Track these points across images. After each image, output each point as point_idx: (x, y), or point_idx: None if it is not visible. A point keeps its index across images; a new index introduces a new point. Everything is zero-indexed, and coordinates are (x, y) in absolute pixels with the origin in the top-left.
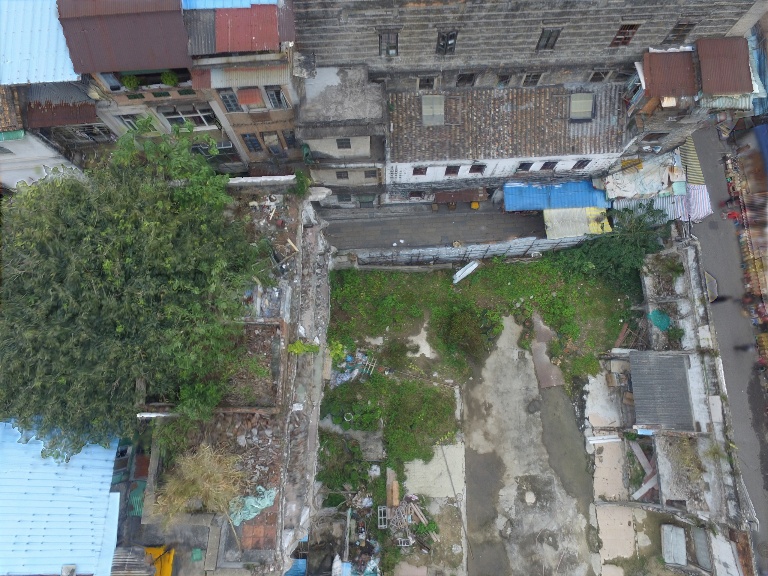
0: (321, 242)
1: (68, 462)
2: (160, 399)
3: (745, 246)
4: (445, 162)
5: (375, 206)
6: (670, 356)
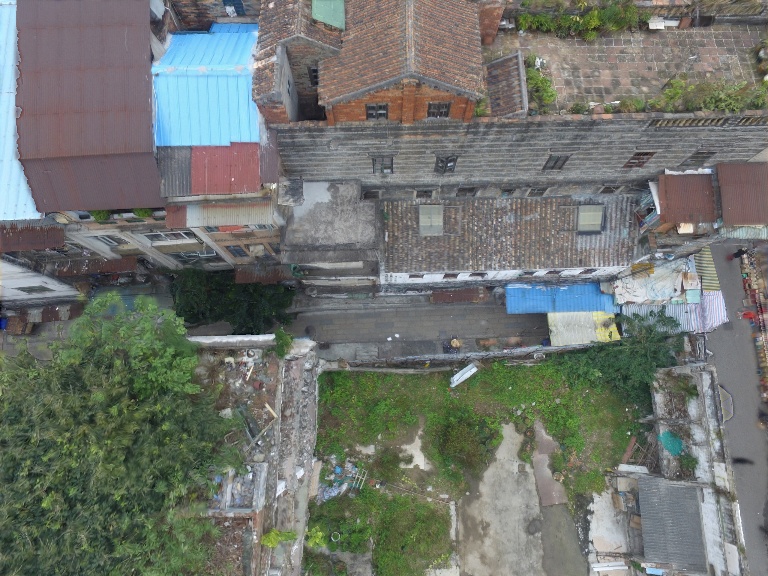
0: (308, 364)
1: None
2: None
3: (762, 351)
4: (443, 271)
5: (370, 297)
6: (682, 486)
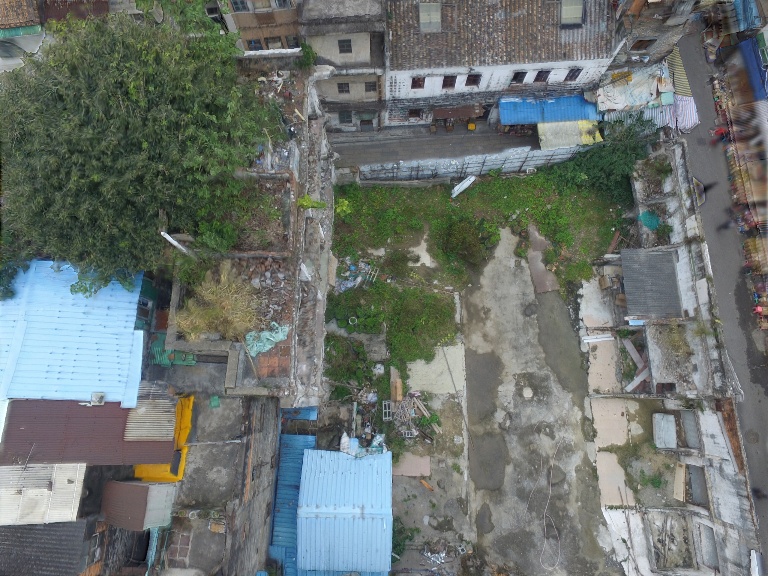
0: (325, 142)
1: (95, 302)
2: (181, 230)
3: (732, 159)
4: (442, 71)
5: (375, 129)
6: (659, 252)
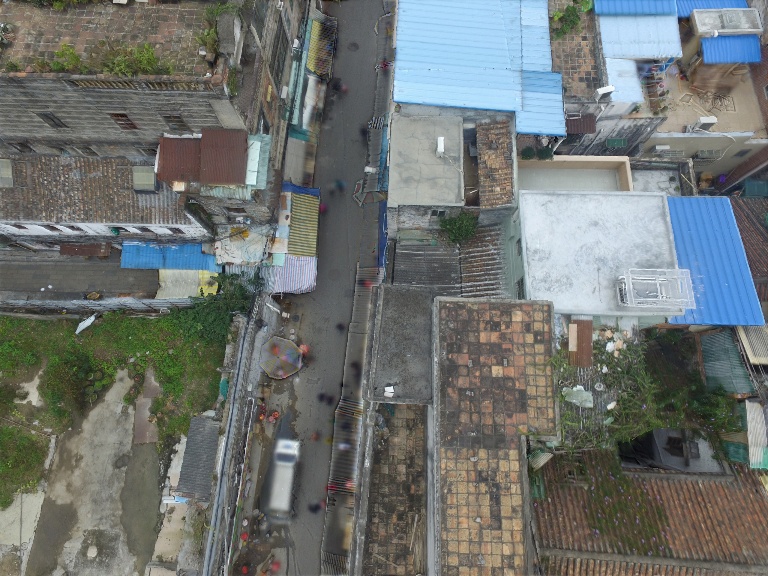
0: None
1: None
2: None
3: None
4: None
5: (30, 250)
6: None
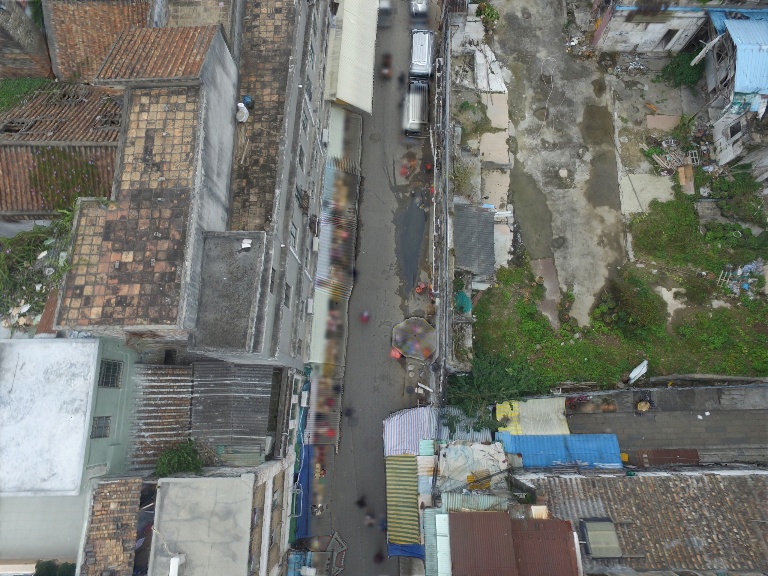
0: None
1: None
2: None
3: None
4: None
5: None
6: None
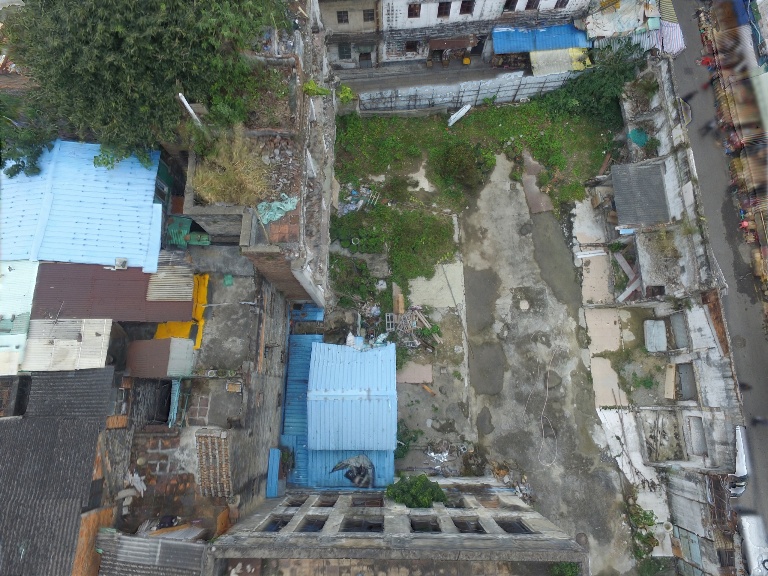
0: (326, 61)
1: None
2: (196, 99)
3: (718, 86)
4: None
5: (374, 65)
6: (648, 166)
